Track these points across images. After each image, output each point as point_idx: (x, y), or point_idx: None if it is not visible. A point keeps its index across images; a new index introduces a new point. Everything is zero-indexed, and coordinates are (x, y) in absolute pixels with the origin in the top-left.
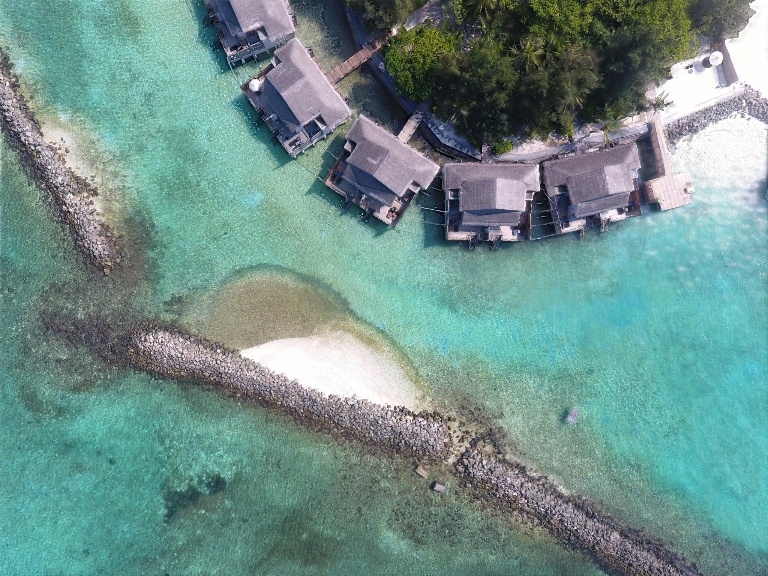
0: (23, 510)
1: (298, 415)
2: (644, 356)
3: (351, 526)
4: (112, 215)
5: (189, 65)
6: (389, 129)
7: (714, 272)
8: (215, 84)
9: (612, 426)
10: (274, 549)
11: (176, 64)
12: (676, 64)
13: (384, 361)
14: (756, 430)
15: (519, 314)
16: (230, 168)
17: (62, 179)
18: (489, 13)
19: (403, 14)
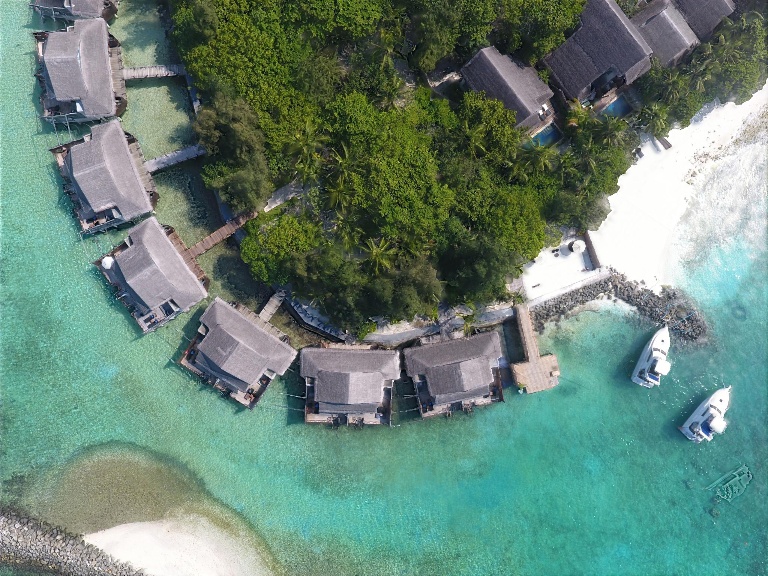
0: None
1: None
2: (511, 539)
3: None
4: None
5: (46, 231)
6: (254, 303)
7: (582, 452)
8: (73, 251)
9: None
10: None
11: (32, 230)
12: None
13: (239, 547)
14: None
15: (384, 495)
16: (84, 339)
17: None
18: (345, 207)
19: (258, 204)
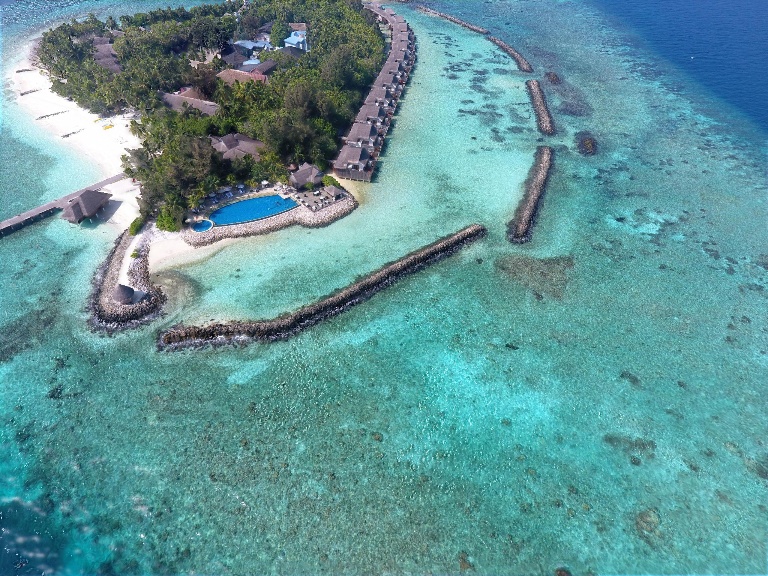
0: None
1: None
2: None
3: None
4: None
5: None
6: None
7: None
8: None
9: None
10: None
11: None
12: None
13: None
14: None
15: None
16: None
17: None
18: None
19: None
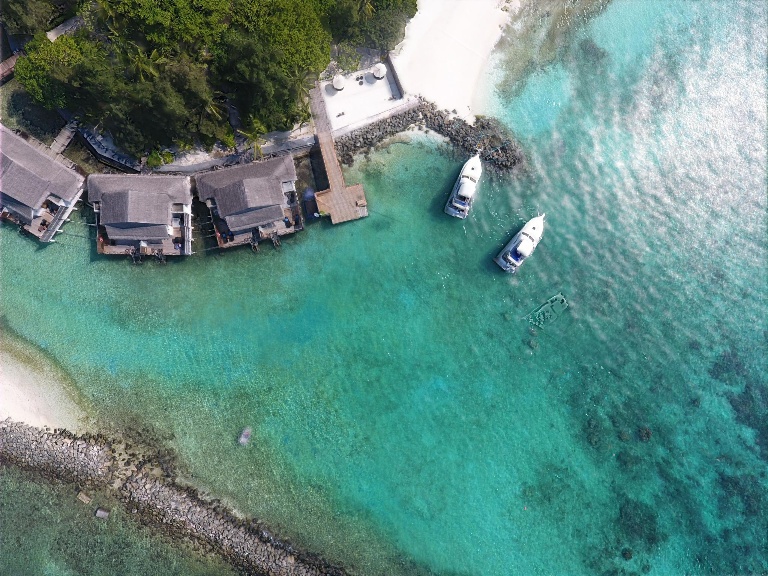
0: None
1: None
2: (325, 373)
3: (9, 557)
4: None
5: None
6: (51, 139)
7: (397, 286)
8: None
9: (291, 446)
10: None
11: None
12: (337, 75)
13: (44, 381)
14: (442, 447)
15: (192, 330)
16: None
17: None
18: (117, 20)
19: (28, 20)
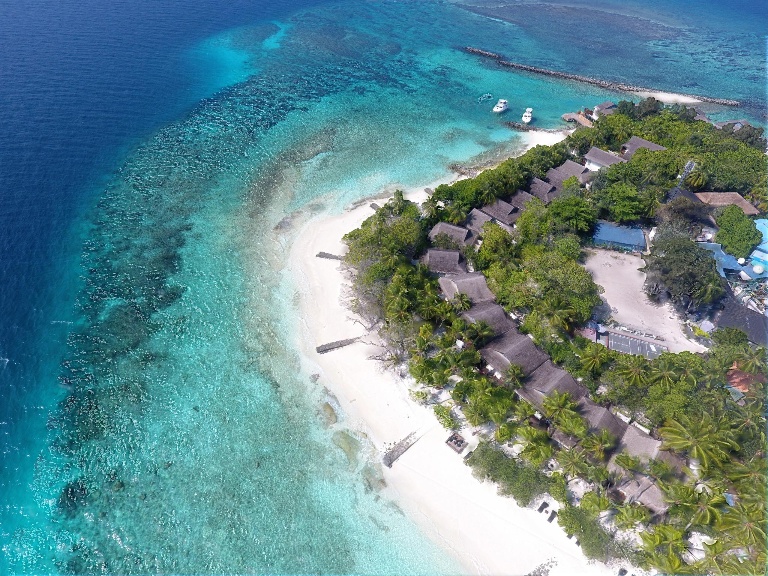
0: None
1: None
2: None
3: None
4: None
5: None
6: None
7: None
8: None
9: None
10: None
11: None
12: None
13: None
14: None
15: None
16: None
17: None
18: None
19: None
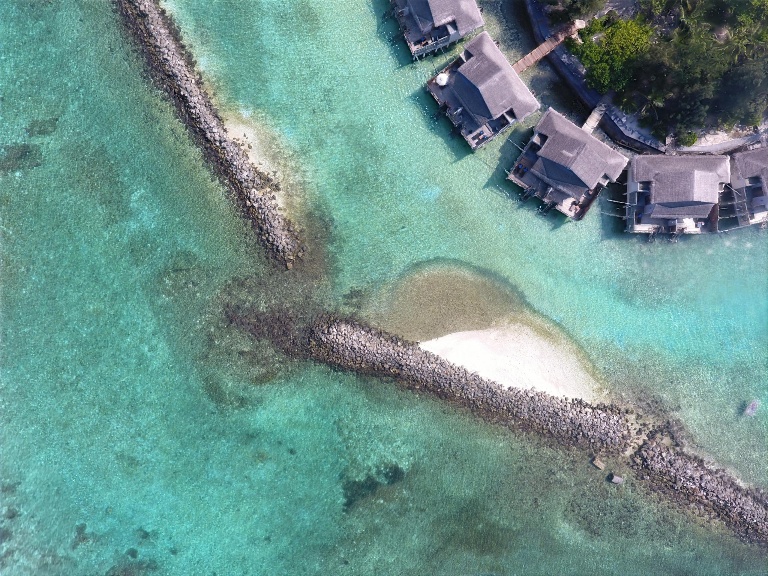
0: (207, 498)
1: (476, 407)
2: None
3: (527, 517)
4: (293, 210)
5: (368, 60)
6: None
7: None
8: (393, 79)
9: None
10: (451, 538)
11: (355, 59)
12: None
13: (561, 354)
14: None
15: (696, 307)
16: (408, 162)
17: (247, 175)
18: (690, 3)
19: (601, 5)
